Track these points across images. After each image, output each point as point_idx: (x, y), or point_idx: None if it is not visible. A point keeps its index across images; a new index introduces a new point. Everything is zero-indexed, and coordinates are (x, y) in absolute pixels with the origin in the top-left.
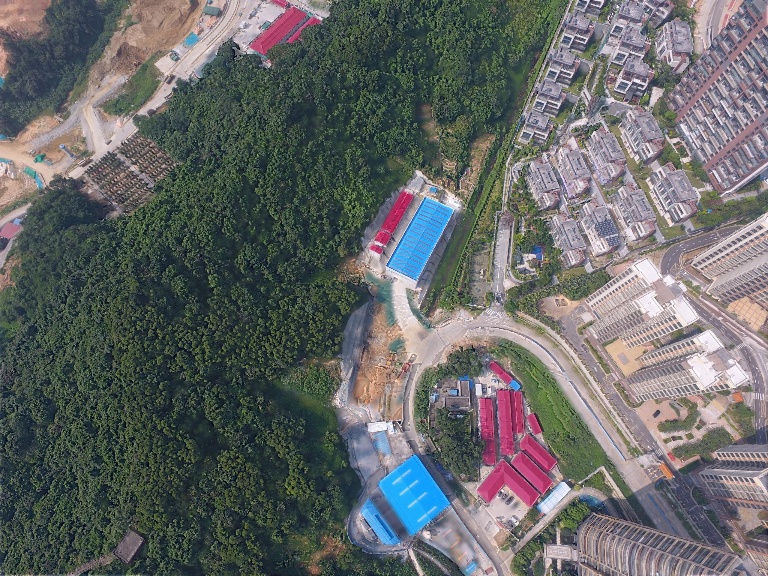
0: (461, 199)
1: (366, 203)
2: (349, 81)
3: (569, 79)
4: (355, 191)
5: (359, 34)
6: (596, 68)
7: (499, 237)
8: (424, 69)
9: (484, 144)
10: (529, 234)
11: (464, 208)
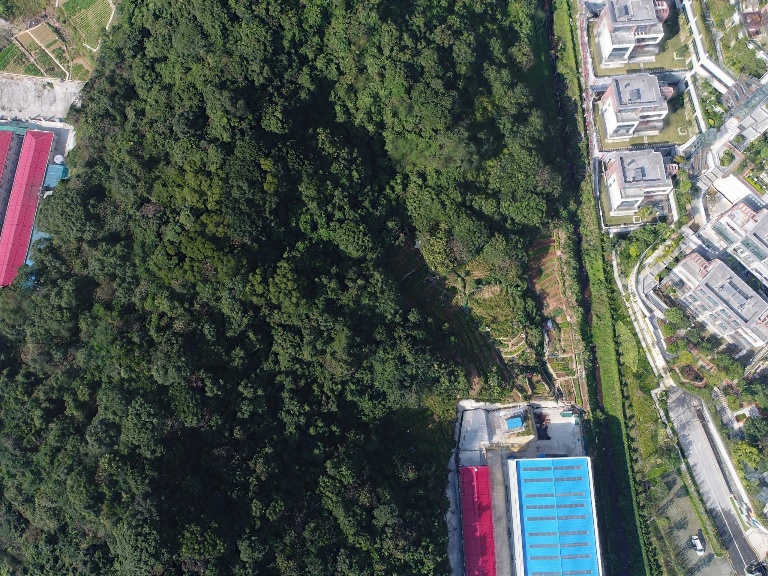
0: (570, 401)
1: (422, 574)
2: (236, 325)
3: (653, 45)
4: (391, 573)
5: (195, 199)
6: (698, 0)
7: (687, 446)
8: (369, 185)
9: (550, 256)
10: (766, 440)
11: (586, 417)
